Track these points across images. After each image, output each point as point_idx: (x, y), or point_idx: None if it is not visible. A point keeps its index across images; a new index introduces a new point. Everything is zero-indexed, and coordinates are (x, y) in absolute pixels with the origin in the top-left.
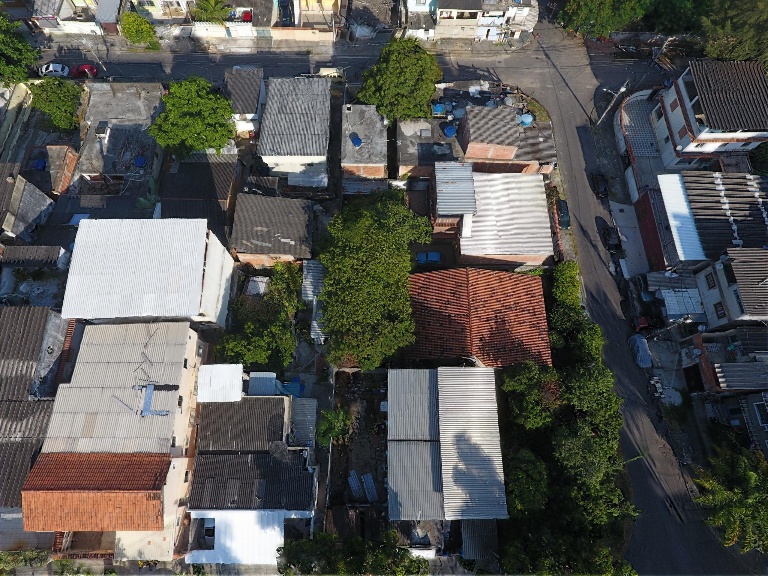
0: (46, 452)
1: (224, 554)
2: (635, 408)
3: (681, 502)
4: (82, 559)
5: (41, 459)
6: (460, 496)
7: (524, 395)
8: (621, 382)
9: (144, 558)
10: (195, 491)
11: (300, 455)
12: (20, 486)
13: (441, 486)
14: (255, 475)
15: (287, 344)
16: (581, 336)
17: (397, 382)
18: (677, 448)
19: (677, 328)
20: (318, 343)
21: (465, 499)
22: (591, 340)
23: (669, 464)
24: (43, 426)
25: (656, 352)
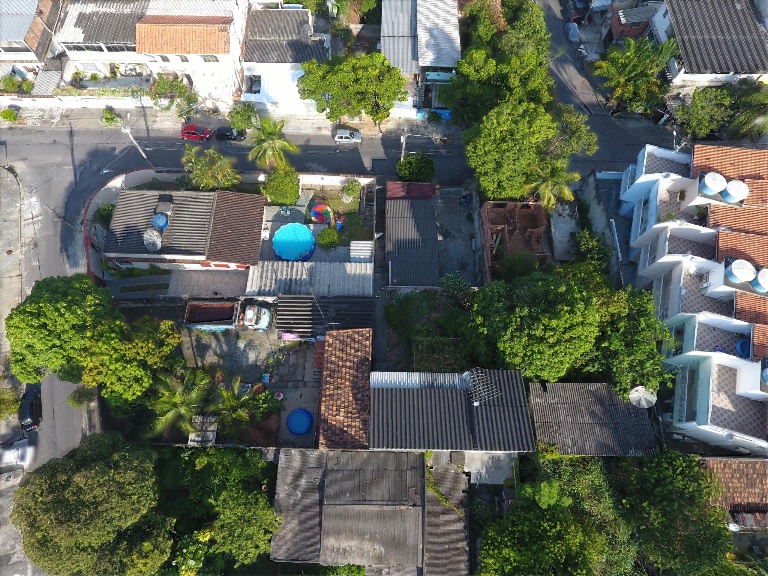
0: (149, 14)
1: (267, 96)
2: (565, 63)
3: (592, 106)
4: (167, 112)
5: (146, 17)
6: (430, 55)
7: (478, 16)
8: (556, 50)
9: (212, 97)
10: (248, 55)
11: (320, 42)
12: (132, 32)
13: (417, 58)
14: (289, 50)
15: (310, 5)
16: (525, 6)
17: (388, 6)
18: (593, 82)
19: (600, 15)
20: (332, 15)
21: (433, 56)
22: (532, 6)
23: (586, 89)
24: (145, 7)
25: (584, 34)
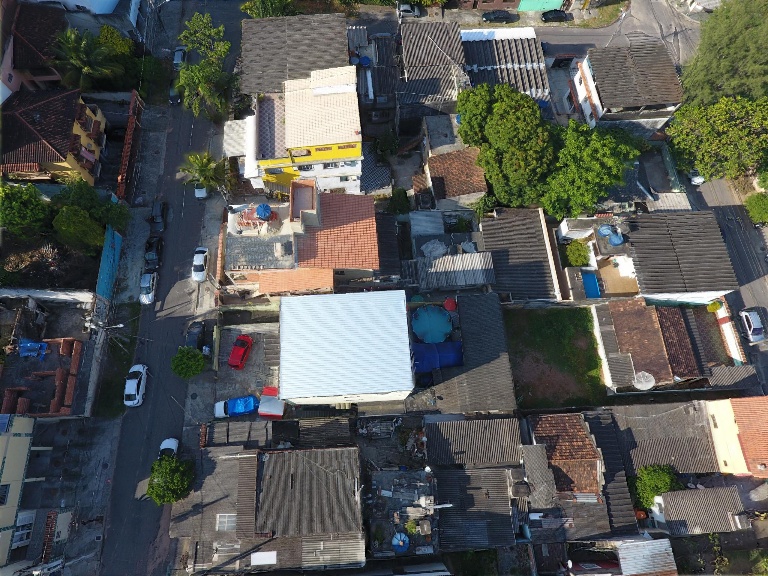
0: None
1: None
2: None
3: None
4: None
5: None
6: None
7: None
8: None
9: None
10: None
11: None
12: None
13: None
14: None
15: None
16: None
17: None
18: None
19: None
20: None
21: None
22: None
23: None
24: None
25: None
